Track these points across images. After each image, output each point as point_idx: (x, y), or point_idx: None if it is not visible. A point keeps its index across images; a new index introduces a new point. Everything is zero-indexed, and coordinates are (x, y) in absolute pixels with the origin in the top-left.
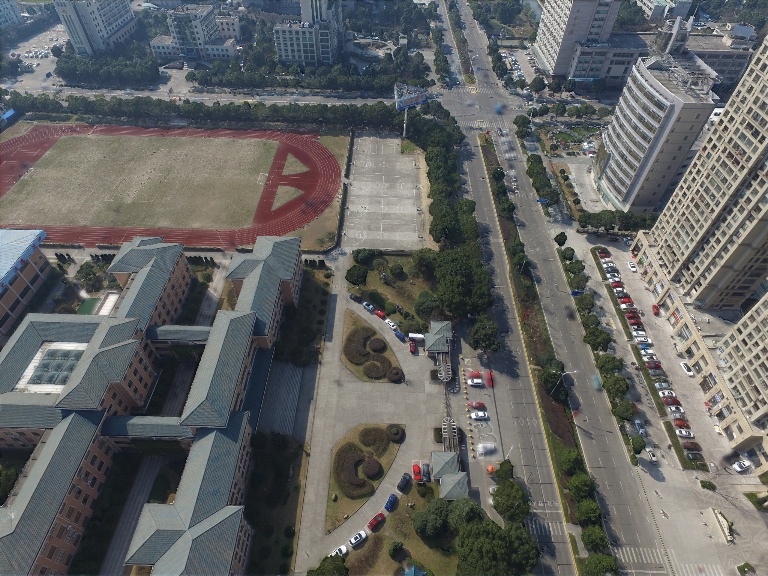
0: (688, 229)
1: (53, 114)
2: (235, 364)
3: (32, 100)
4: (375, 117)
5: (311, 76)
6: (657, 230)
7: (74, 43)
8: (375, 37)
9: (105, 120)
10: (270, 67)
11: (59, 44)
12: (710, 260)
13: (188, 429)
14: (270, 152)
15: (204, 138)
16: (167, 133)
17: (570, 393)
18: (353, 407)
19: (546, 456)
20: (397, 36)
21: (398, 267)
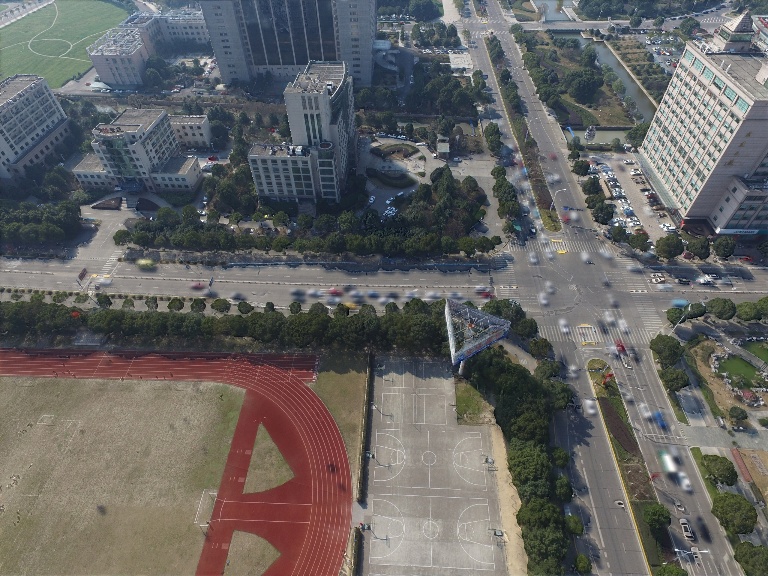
0: None
1: None
2: None
3: None
4: (410, 342)
5: (306, 230)
6: None
7: None
8: (401, 136)
9: None
10: (246, 207)
11: None
12: None
13: None
14: (228, 421)
15: (121, 381)
16: (63, 368)
17: None
18: None
19: None
20: (434, 138)
21: None
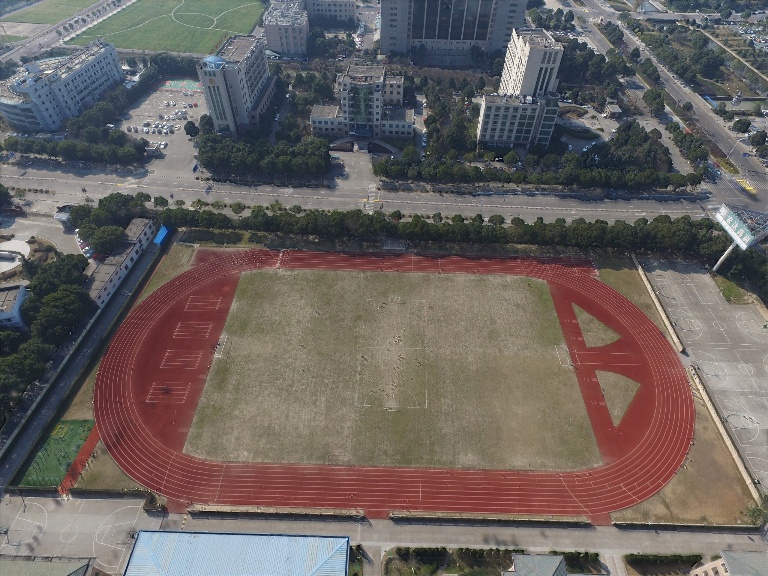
0: None
1: (215, 230)
2: None
3: (192, 215)
4: (675, 244)
5: (536, 167)
6: None
7: (215, 119)
8: (568, 100)
9: (289, 241)
10: (470, 150)
11: (181, 112)
12: None
13: None
14: (545, 301)
15: (439, 274)
16: (384, 265)
17: None
18: None
19: None
20: (603, 101)
21: None
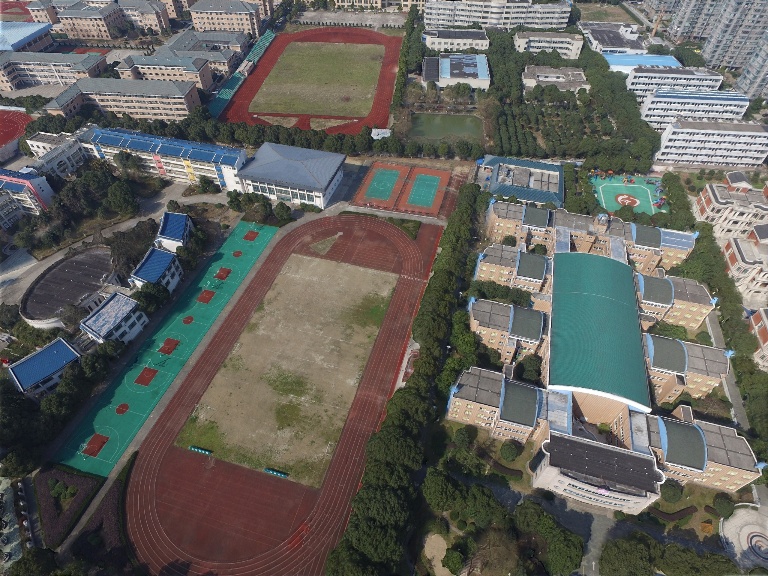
0: None
1: None
2: None
3: None
4: None
5: None
6: None
7: None
8: None
9: None
10: None
11: None
12: None
13: None
14: None
15: None
16: None
17: None
18: None
19: None
20: None
21: None
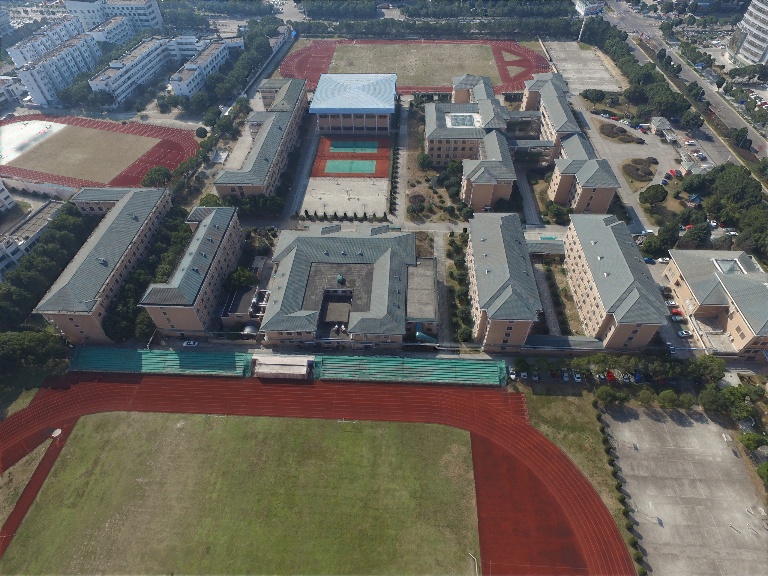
0: None
1: (319, 35)
2: (570, 112)
3: (309, 24)
4: (558, 27)
5: (493, 8)
6: None
7: None
8: None
9: (358, 37)
10: None
11: None
12: None
13: (551, 142)
14: (488, 50)
15: (436, 44)
16: (408, 42)
17: (750, 147)
18: (621, 153)
19: None
20: None
21: (617, 97)
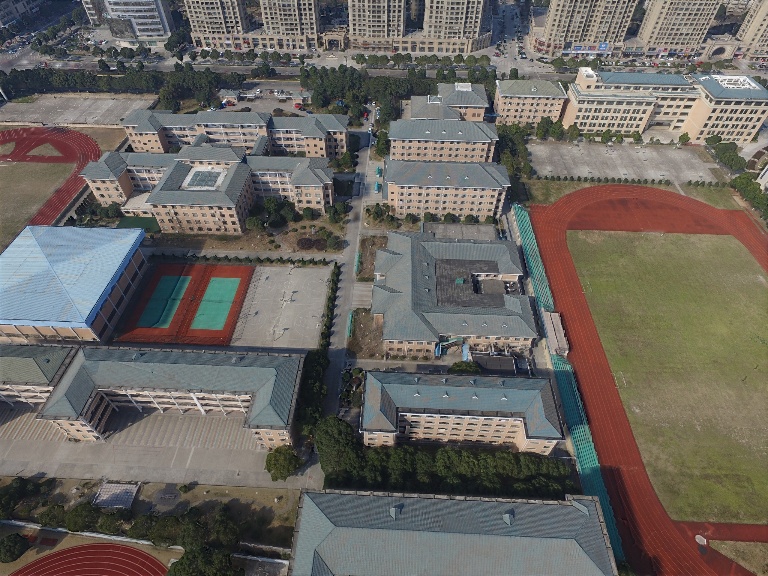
0: (211, 6)
1: None
2: None
3: None
4: None
5: None
6: (195, 27)
7: None
8: None
9: None
10: None
11: None
12: (232, 8)
13: (264, 137)
14: None
15: None
16: None
17: None
18: None
19: (299, 82)
20: None
21: None
